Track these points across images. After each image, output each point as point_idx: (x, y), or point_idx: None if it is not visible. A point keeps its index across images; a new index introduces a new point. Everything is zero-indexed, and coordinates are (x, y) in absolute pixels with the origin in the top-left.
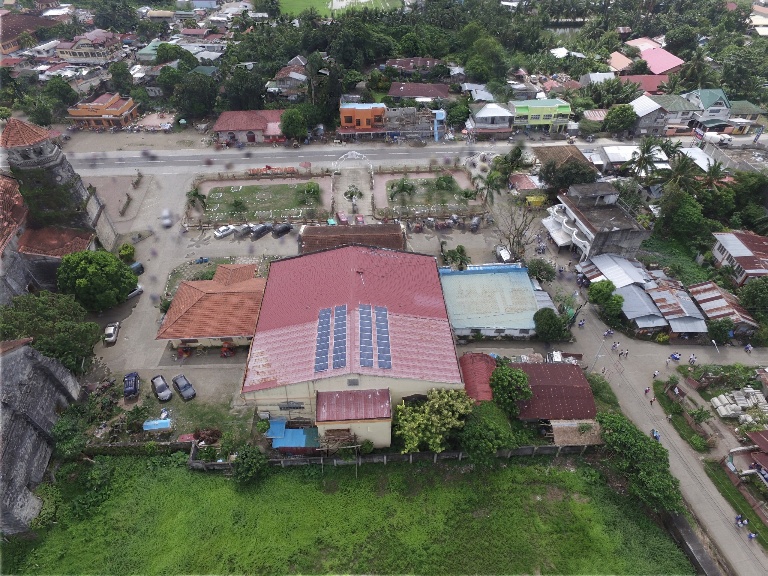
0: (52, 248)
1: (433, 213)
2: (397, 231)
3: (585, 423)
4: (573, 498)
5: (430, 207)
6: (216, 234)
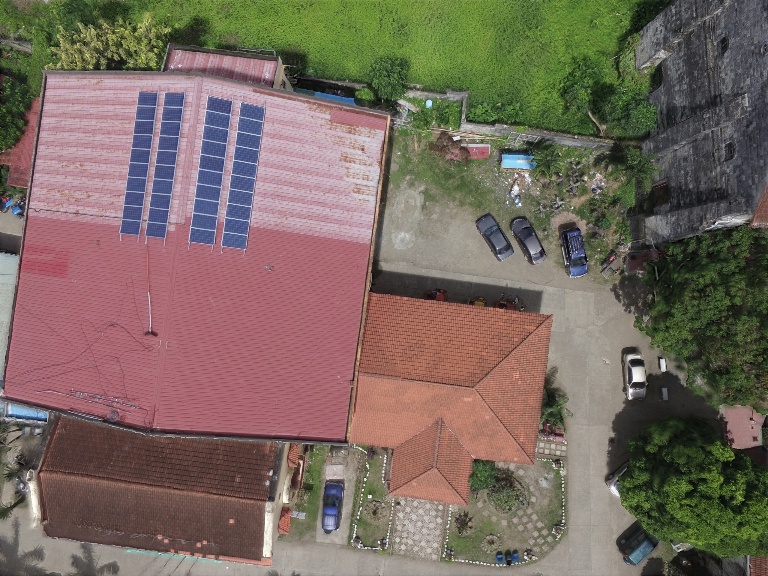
0: None
1: None
2: (54, 489)
3: None
4: None
5: None
6: None
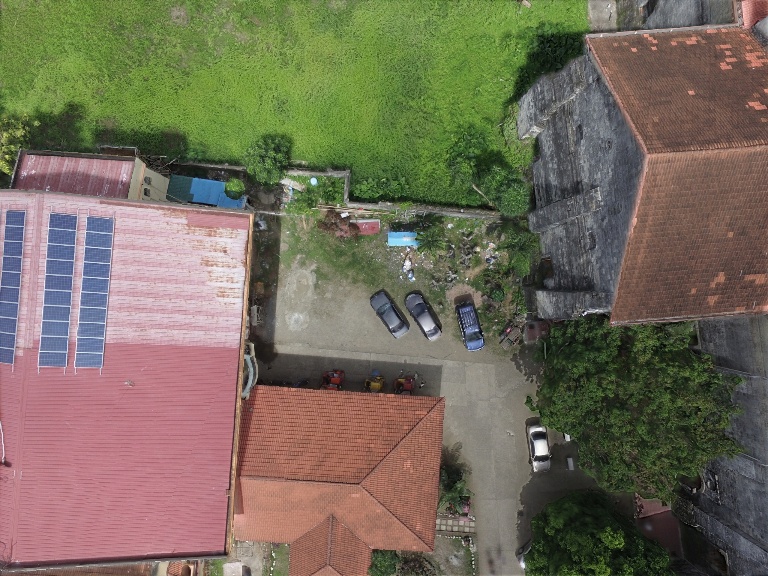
0: None
1: None
2: None
3: None
4: None
5: None
6: None
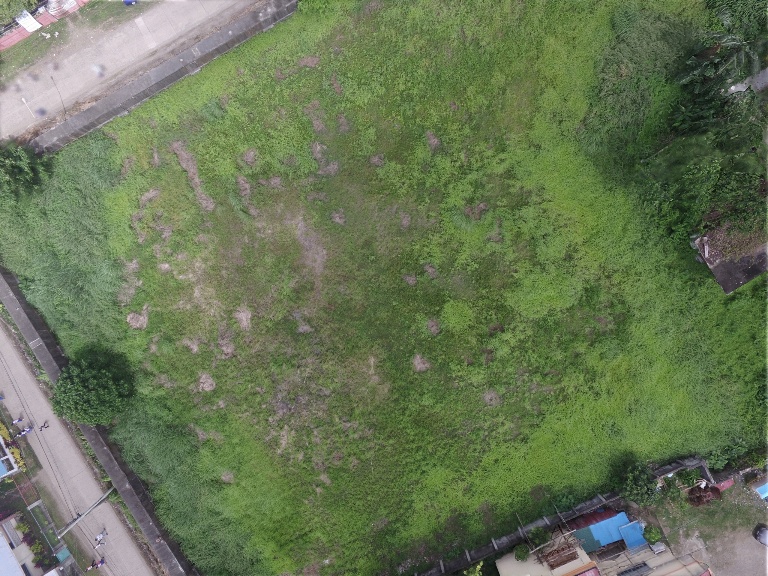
0: None
1: None
2: None
3: None
4: (293, 575)
5: None
6: None
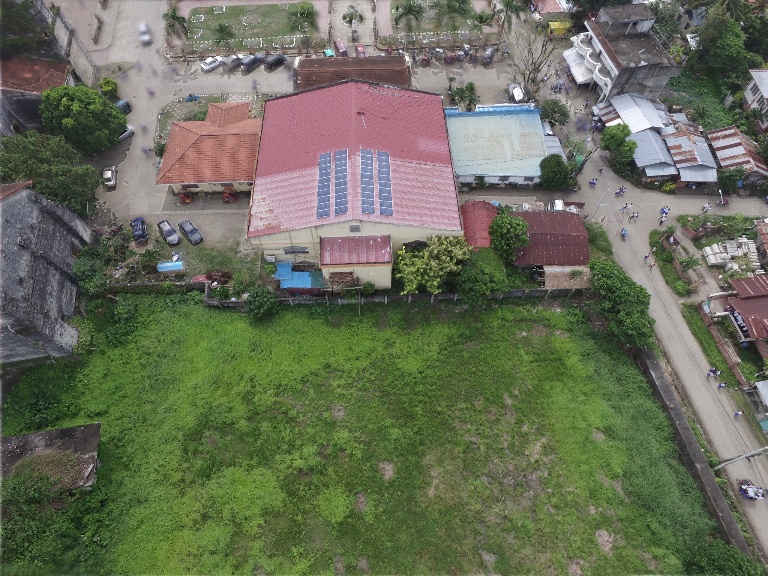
0: (27, 82)
1: (442, 42)
2: (401, 65)
3: (576, 269)
4: (555, 334)
5: (439, 35)
6: (203, 67)
